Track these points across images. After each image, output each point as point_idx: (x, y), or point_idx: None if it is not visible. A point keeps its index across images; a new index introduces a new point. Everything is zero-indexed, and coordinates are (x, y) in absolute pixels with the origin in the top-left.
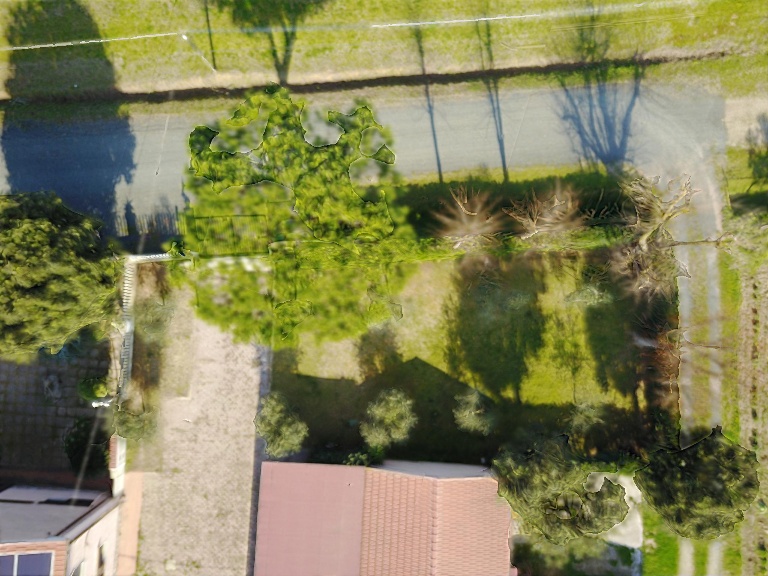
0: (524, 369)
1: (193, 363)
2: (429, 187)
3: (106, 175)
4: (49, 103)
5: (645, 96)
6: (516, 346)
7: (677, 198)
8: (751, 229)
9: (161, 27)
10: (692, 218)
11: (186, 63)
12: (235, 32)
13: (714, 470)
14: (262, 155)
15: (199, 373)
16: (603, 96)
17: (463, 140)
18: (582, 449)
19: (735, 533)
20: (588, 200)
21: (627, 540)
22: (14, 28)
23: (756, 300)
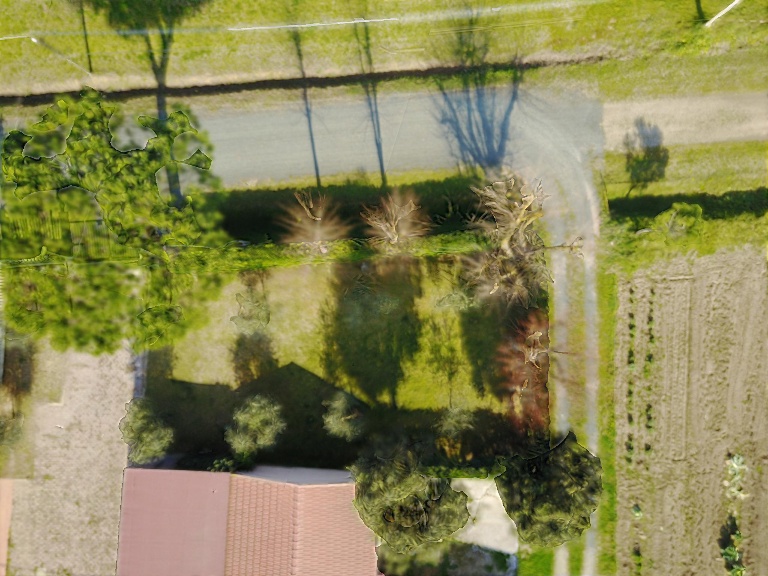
0: (400, 374)
1: (66, 369)
2: None
3: None
4: None
5: (523, 100)
6: (392, 351)
7: (526, 203)
8: (627, 233)
9: (36, 30)
10: (570, 222)
11: (62, 66)
12: (111, 35)
13: (557, 477)
14: (66, 160)
15: (72, 379)
16: (481, 100)
17: (341, 144)
18: (458, 455)
19: (610, 539)
20: (468, 204)
21: (502, 546)
22: None
23: (633, 305)
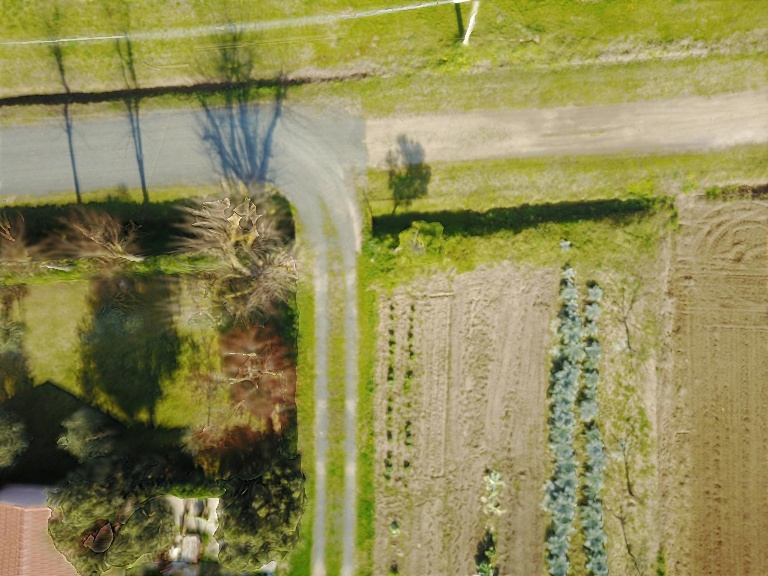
0: (158, 393)
1: None
2: (67, 208)
3: None
4: None
5: (287, 117)
6: (151, 369)
7: (233, 223)
8: (387, 250)
9: None
10: (333, 239)
11: None
12: None
13: (251, 499)
14: None
15: None
16: (245, 116)
17: (102, 160)
18: (216, 474)
19: (367, 557)
20: None
21: None
22: None
23: (393, 322)
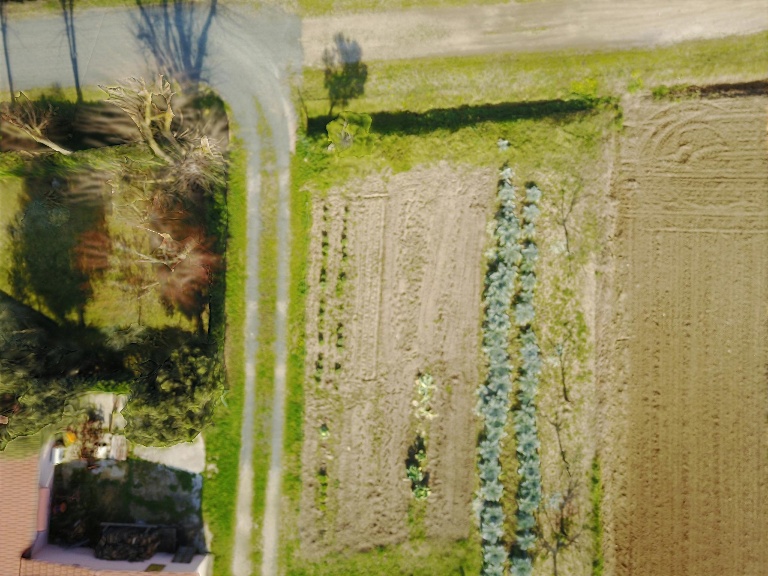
0: (90, 291)
1: None
2: (1, 106)
3: None
4: None
5: (221, 15)
6: (82, 268)
7: (145, 99)
8: (321, 150)
9: None
10: (267, 139)
11: None
12: None
13: None
14: None
15: None
16: (179, 14)
17: (36, 58)
18: None
19: (296, 458)
20: None
21: (189, 465)
22: None
23: (326, 222)
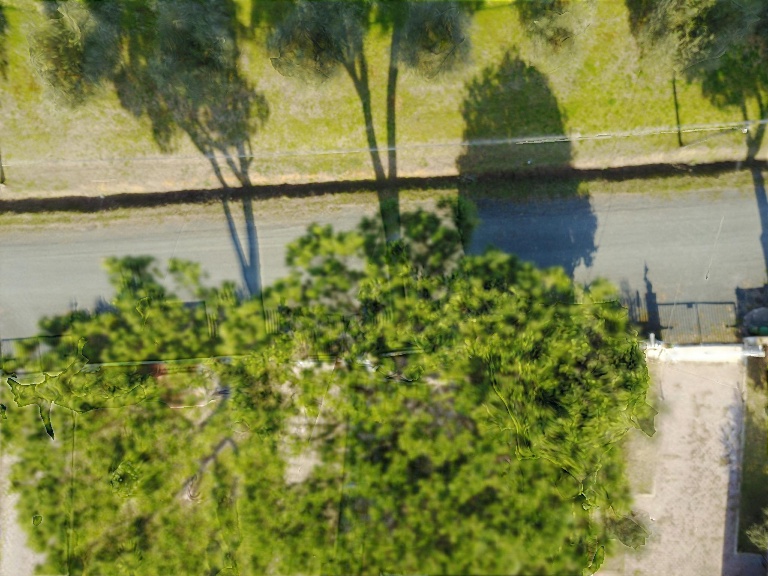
0: None
1: (657, 458)
2: None
3: (565, 257)
4: (498, 180)
5: None
6: None
7: None
8: None
9: (623, 100)
10: None
11: (649, 138)
12: (705, 105)
13: None
14: None
15: (663, 469)
16: None
17: None
18: None
19: None
20: None
21: None
22: (468, 102)
23: None
